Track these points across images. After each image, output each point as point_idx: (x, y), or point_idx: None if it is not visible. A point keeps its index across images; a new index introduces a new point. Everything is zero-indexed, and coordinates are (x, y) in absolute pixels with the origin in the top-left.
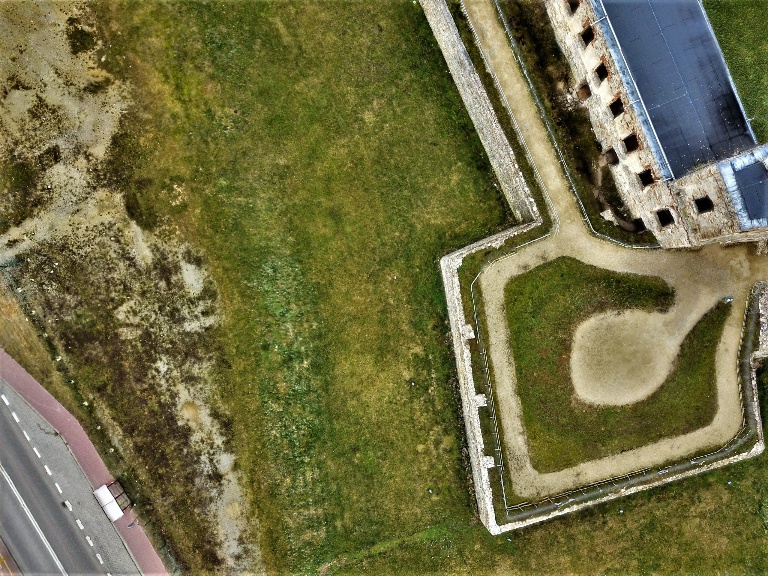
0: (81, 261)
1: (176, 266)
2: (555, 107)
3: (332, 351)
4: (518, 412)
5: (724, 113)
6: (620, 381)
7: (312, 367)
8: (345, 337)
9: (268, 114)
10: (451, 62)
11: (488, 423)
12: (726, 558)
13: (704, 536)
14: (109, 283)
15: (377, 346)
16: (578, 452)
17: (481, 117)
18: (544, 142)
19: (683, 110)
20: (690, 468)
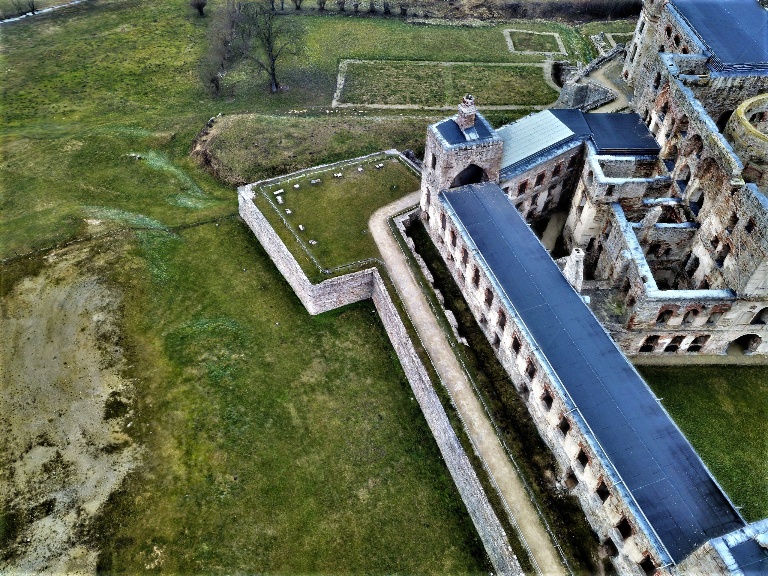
0: None
1: None
2: (544, 491)
3: None
4: None
5: (708, 499)
6: None
7: None
8: None
9: (266, 484)
10: (443, 448)
11: None
12: None
13: None
14: None
15: None
16: None
17: (472, 498)
18: (536, 525)
19: (666, 493)
20: None
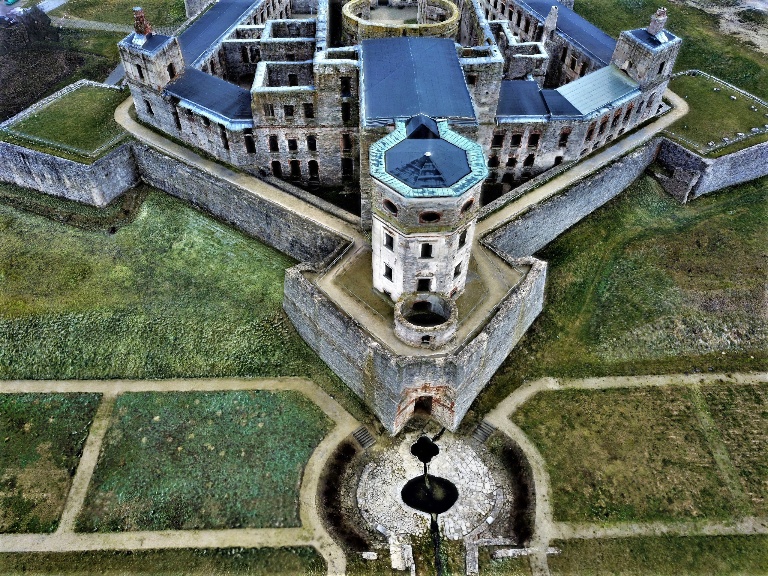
0: (713, 3)
1: None
2: None
3: None
4: None
5: None
6: None
7: None
8: None
9: None
10: None
11: None
12: None
13: None
14: None
15: None
16: None
17: None
18: None
19: None
20: None
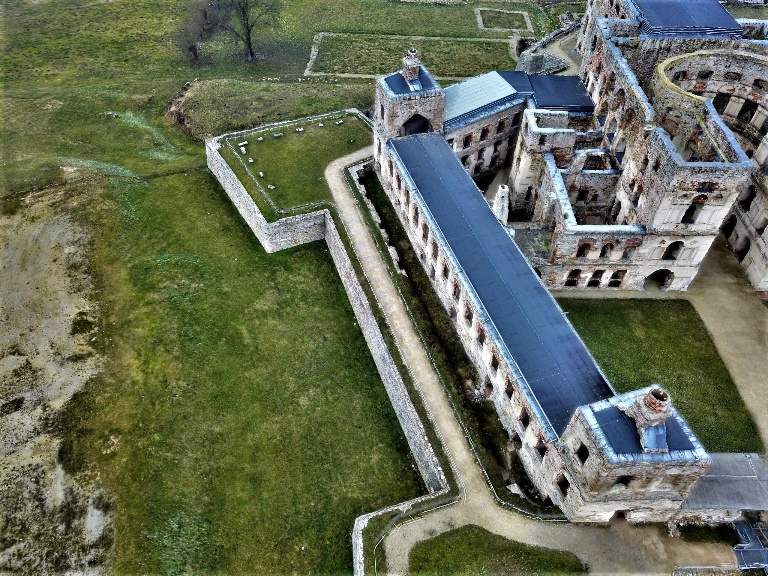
0: None
1: (83, 511)
2: (461, 393)
3: None
4: None
5: (595, 389)
6: None
7: None
8: None
9: (216, 390)
10: (379, 363)
11: None
12: None
13: None
14: (9, 523)
15: None
16: None
17: (399, 402)
18: (451, 420)
19: (559, 385)
20: None
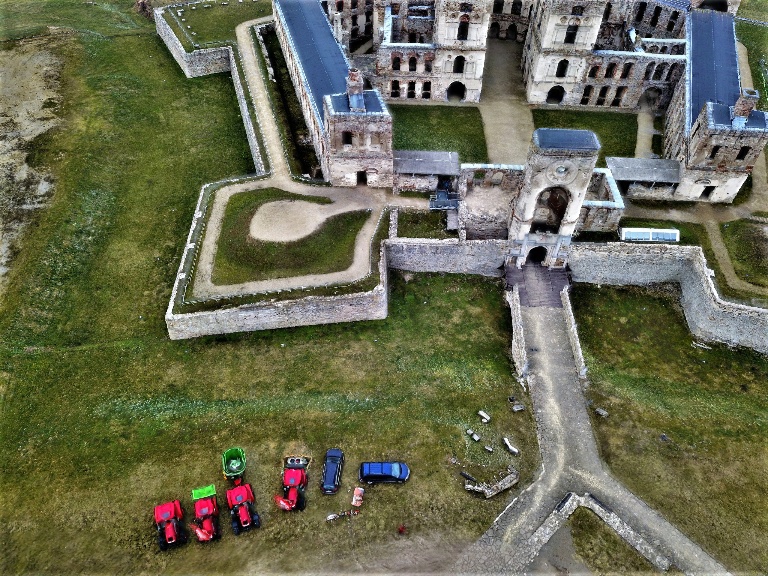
0: None
1: (37, 182)
2: None
3: (112, 237)
4: (213, 252)
5: None
6: (281, 230)
7: (94, 241)
8: (125, 232)
9: (134, 140)
10: None
11: (191, 257)
12: (360, 384)
13: (346, 369)
14: None
15: (144, 239)
16: (247, 276)
17: None
18: (278, 146)
19: None
20: (327, 295)
